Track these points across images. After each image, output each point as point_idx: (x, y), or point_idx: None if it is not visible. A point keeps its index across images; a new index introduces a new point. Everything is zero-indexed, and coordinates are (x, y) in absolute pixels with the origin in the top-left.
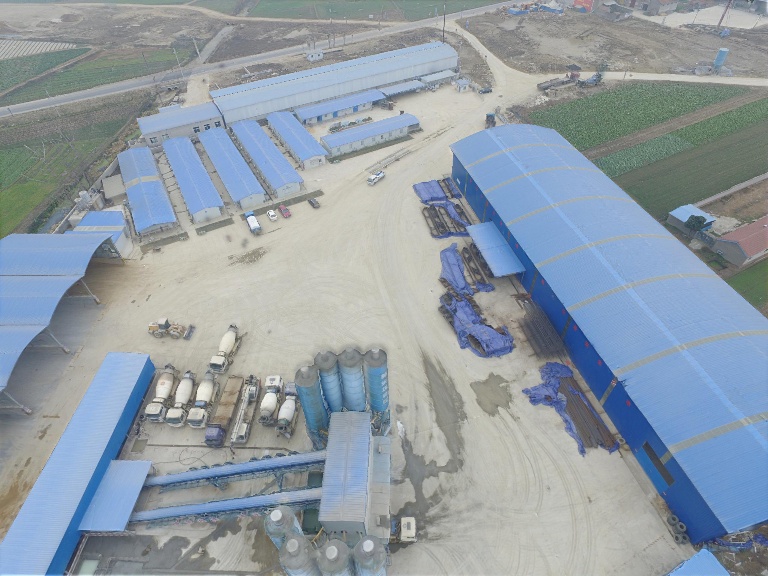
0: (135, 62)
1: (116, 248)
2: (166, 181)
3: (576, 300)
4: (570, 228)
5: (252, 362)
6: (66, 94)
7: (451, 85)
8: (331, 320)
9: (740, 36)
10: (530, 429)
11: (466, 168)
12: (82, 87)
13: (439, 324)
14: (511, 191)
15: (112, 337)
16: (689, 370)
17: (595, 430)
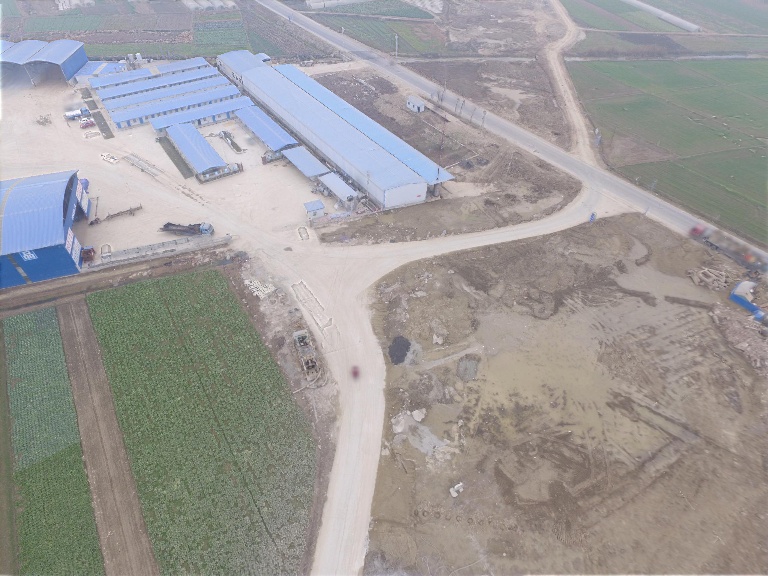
0: (406, 38)
1: (64, 74)
2: None
3: None
4: None
5: None
6: (328, 28)
7: (333, 205)
8: None
9: None
10: None
11: None
12: (350, 32)
13: None
14: None
15: (3, 95)
16: None
17: None
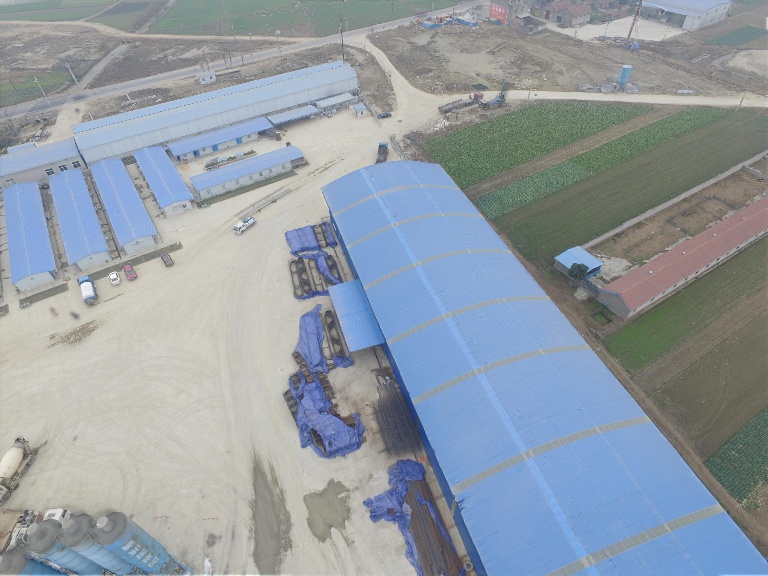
0: (6, 89)
1: None
2: (1, 238)
3: (423, 389)
4: (429, 294)
5: (43, 484)
6: None
7: (349, 109)
8: (154, 417)
9: (649, 49)
10: (364, 557)
11: (334, 216)
12: None
13: (282, 415)
14: (375, 246)
15: None
16: (532, 487)
17: (438, 555)
